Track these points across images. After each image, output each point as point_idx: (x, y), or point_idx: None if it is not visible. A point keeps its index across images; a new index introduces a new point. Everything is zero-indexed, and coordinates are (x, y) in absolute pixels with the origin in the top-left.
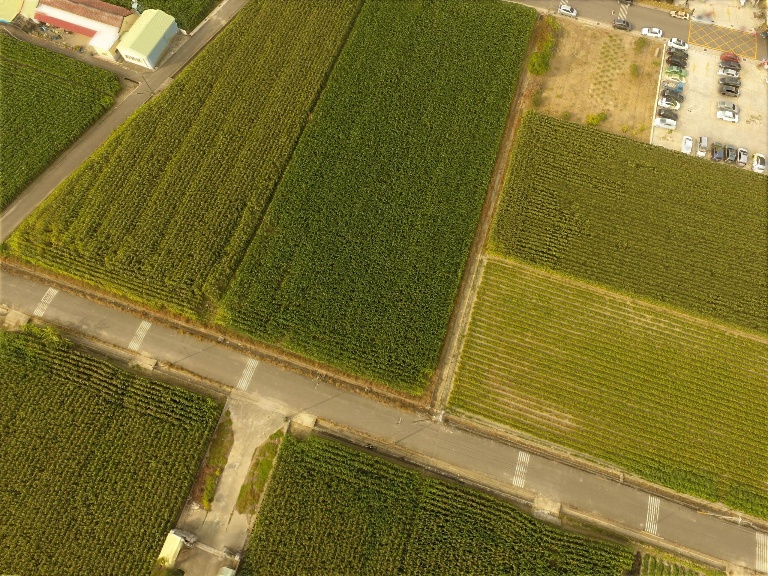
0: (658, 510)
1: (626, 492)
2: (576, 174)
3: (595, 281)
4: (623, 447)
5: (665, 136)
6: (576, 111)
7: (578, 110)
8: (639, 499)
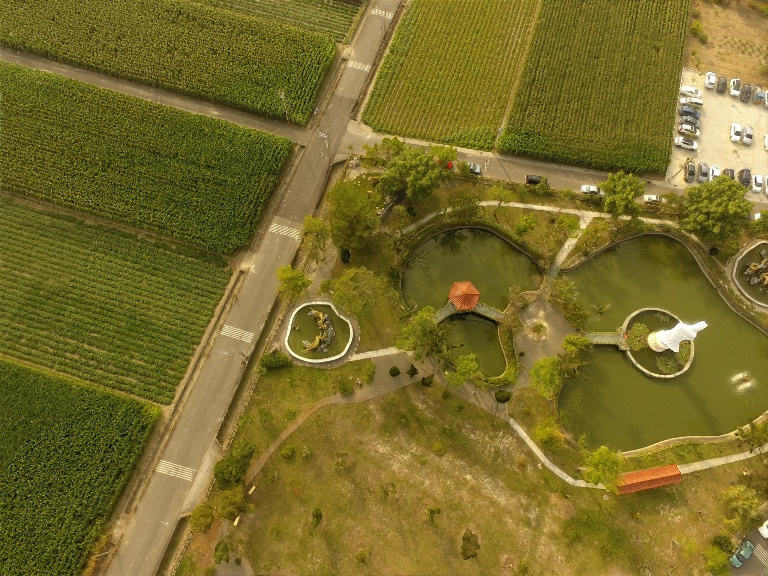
0: (385, 17)
1: (396, 3)
2: (637, 6)
3: (543, 2)
4: (424, 7)
5: (696, 80)
6: (705, 24)
7: (706, 25)
8: (392, 8)
